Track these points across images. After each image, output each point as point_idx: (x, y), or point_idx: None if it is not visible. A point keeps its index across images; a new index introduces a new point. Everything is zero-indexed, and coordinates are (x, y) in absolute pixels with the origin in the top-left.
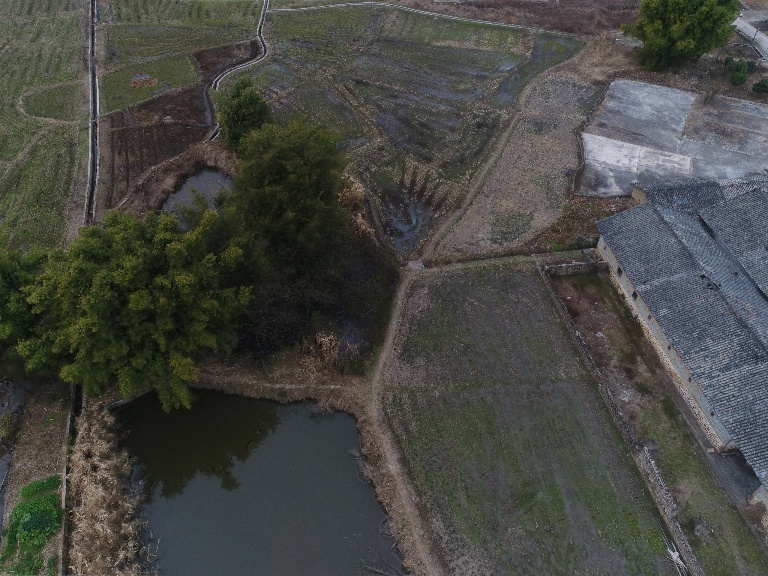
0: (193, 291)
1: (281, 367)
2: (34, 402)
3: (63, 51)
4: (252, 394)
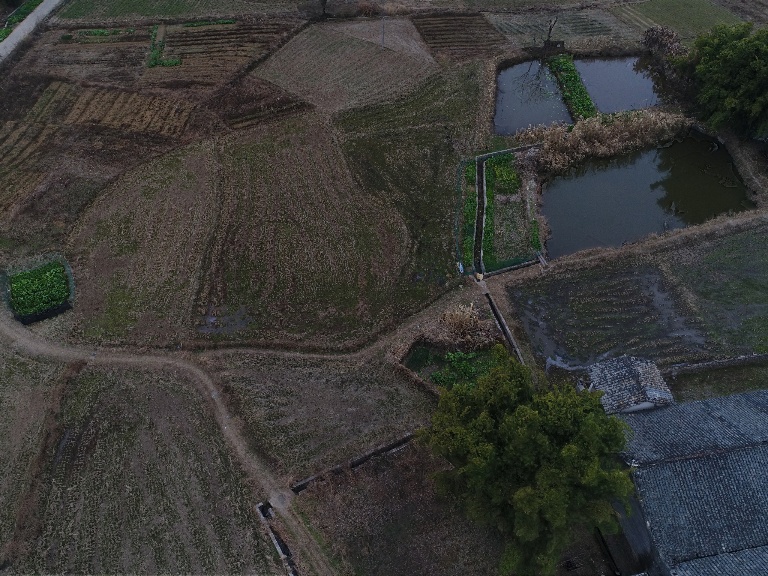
0: None
1: None
2: (681, 103)
3: None
4: (741, 170)
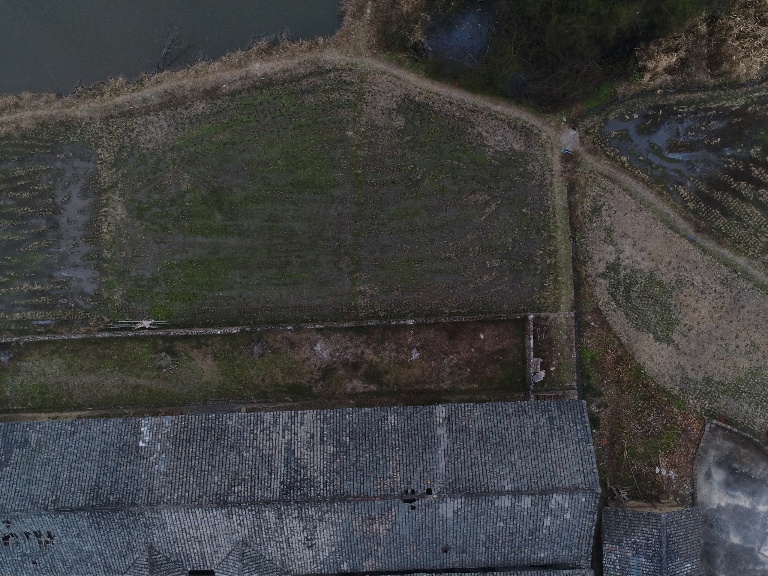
0: None
1: None
2: None
3: None
4: None
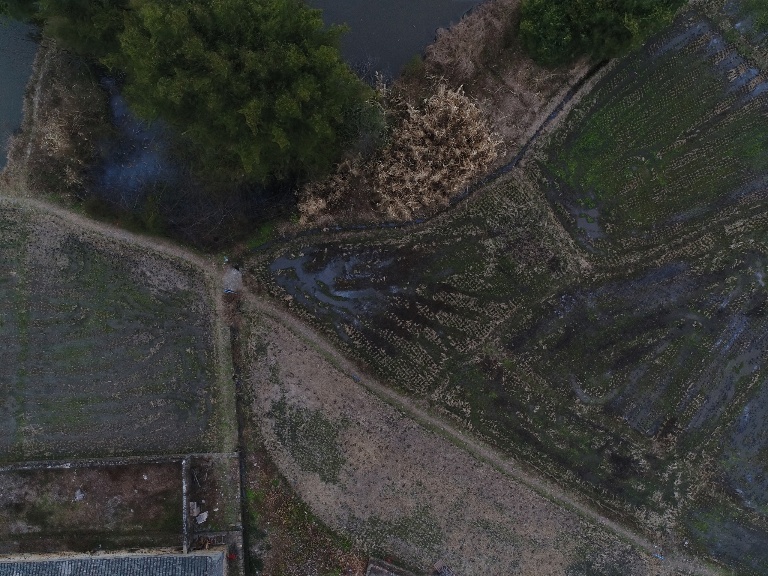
0: None
1: (73, 92)
2: None
3: None
4: None
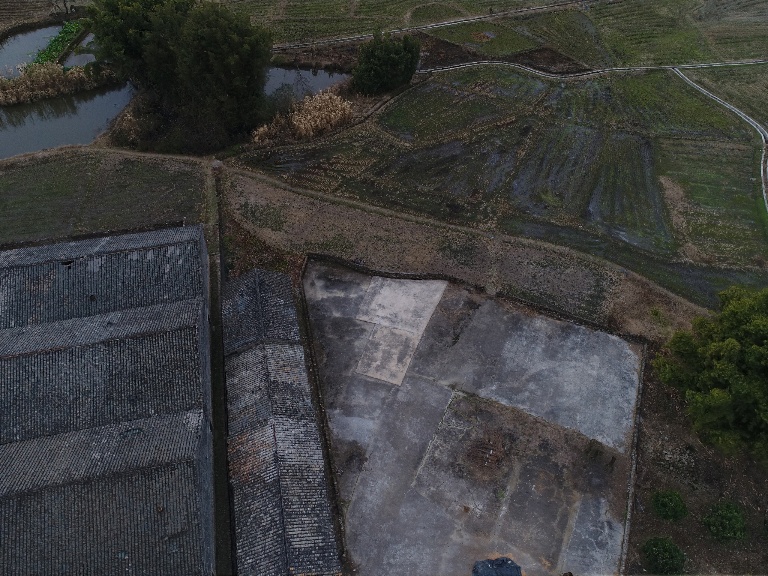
0: (109, 28)
1: None
2: None
3: (518, 2)
4: None
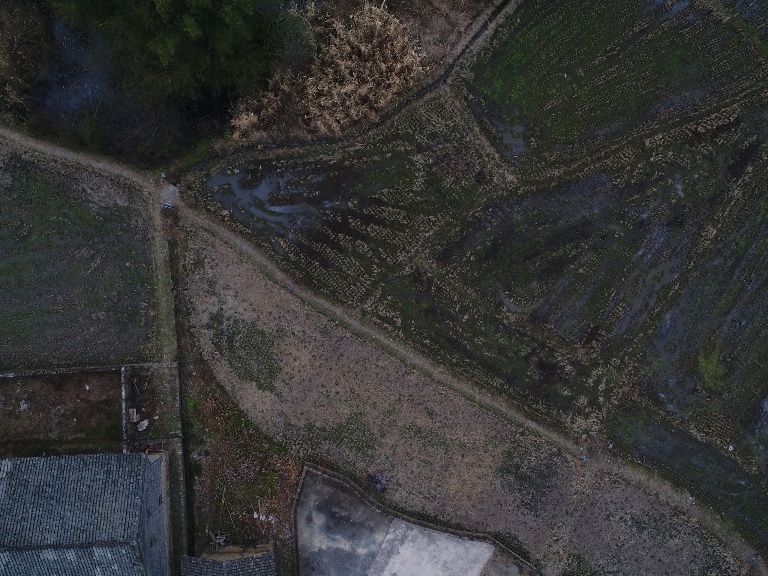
0: None
1: (14, 16)
2: None
3: None
4: None
